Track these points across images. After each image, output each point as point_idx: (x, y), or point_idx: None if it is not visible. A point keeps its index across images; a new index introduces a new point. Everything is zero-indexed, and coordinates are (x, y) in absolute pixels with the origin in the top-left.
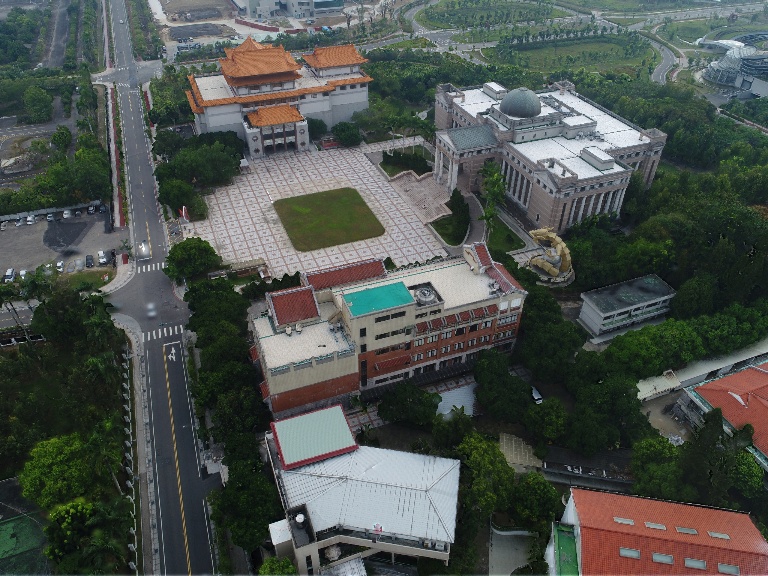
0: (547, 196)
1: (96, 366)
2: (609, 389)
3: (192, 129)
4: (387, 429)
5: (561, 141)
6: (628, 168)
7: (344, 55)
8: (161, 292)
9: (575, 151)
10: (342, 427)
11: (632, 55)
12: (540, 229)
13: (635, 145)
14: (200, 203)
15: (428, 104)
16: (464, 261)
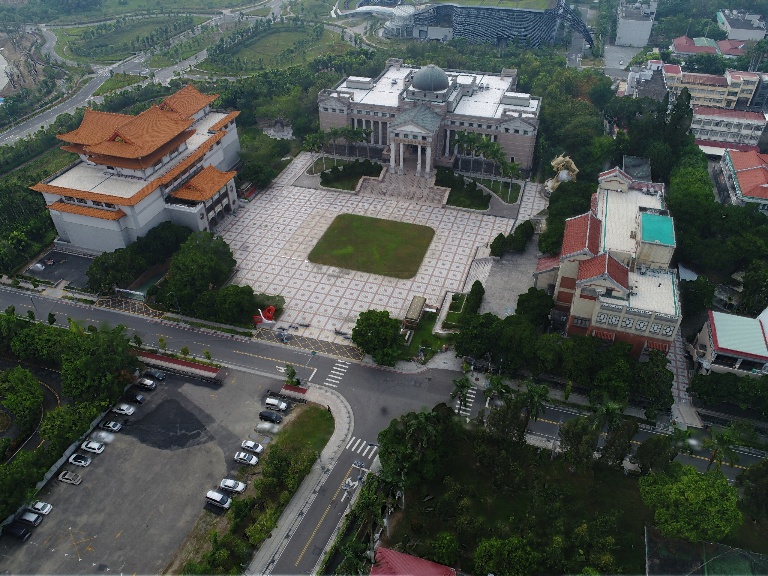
0: (522, 138)
1: (612, 412)
2: (744, 214)
3: (64, 253)
4: (686, 324)
5: (470, 99)
6: (537, 98)
7: (192, 98)
8: (392, 381)
9: (491, 101)
10: (738, 318)
11: (319, 36)
12: (557, 159)
13: (511, 83)
14: (268, 297)
15: (254, 125)
16: (605, 190)
